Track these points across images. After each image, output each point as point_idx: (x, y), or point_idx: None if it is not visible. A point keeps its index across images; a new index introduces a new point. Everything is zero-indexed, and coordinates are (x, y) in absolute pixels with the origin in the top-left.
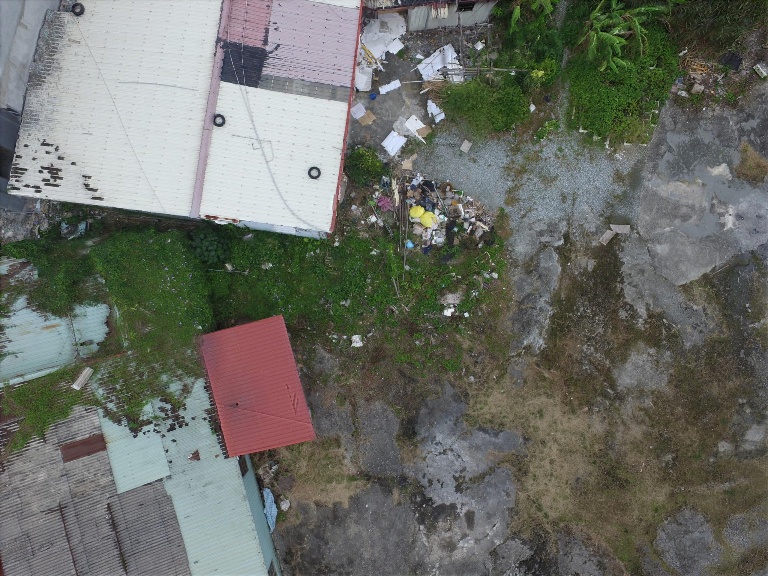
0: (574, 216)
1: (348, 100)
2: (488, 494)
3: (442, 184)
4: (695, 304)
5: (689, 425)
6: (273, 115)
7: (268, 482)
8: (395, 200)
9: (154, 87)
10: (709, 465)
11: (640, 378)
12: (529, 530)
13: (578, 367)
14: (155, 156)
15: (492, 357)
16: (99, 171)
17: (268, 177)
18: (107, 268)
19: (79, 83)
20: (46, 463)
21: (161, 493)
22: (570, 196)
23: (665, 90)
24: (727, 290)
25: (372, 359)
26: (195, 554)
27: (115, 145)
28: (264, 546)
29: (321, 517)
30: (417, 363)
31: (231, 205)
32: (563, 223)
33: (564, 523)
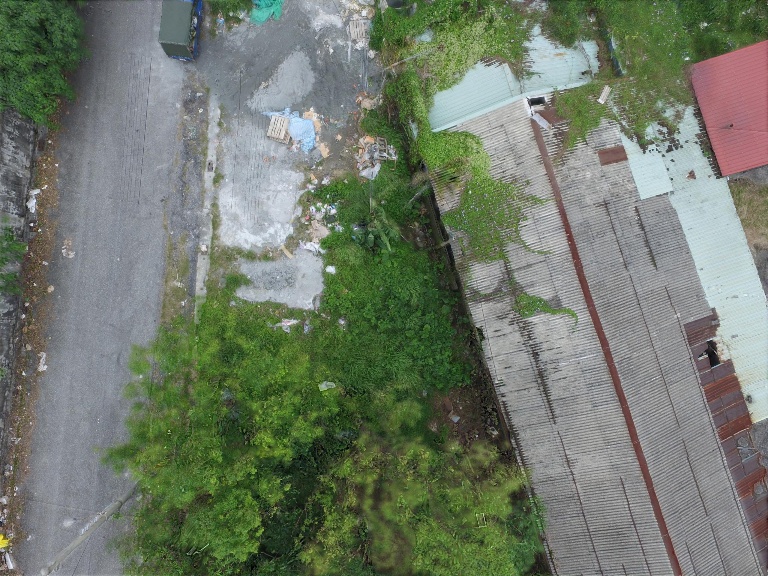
0: None
1: None
2: None
3: None
4: None
5: None
6: None
7: None
8: None
9: None
10: None
11: None
12: None
13: None
14: None
15: None
16: None
17: None
18: None
19: None
20: (590, 163)
21: (668, 205)
22: None
23: None
24: None
25: None
26: (700, 262)
27: None
28: None
29: (761, 259)
30: None
31: None
32: None
33: None
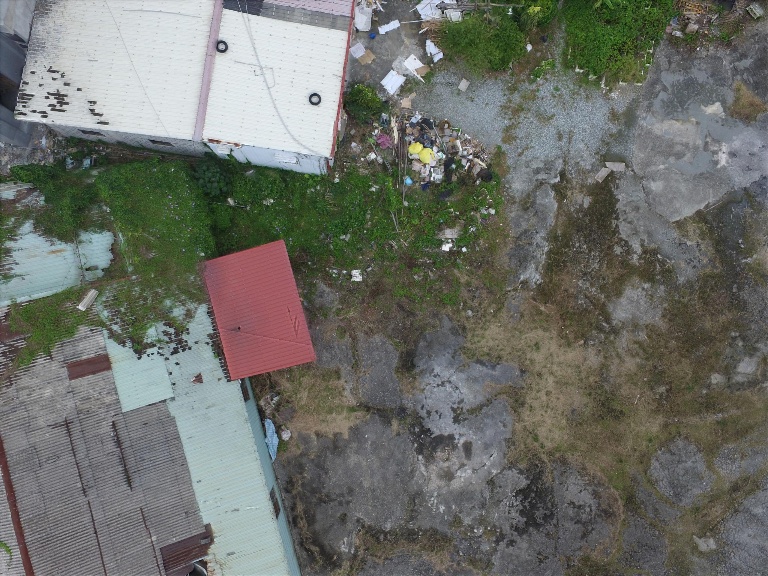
0: (570, 154)
1: (348, 29)
2: (485, 425)
3: (440, 122)
4: (689, 240)
5: (683, 358)
6: (275, 43)
7: (269, 413)
8: (394, 138)
9: (158, 14)
10: (702, 397)
11: (635, 312)
12: (525, 460)
13: (574, 301)
14: (159, 81)
15: (489, 291)
16: (104, 96)
17: (270, 103)
18: (112, 195)
19: (84, 11)
20: (53, 379)
21: (165, 414)
22: (566, 134)
23: (660, 30)
24: (720, 226)
25: (371, 293)
26: (198, 473)
27: (120, 71)
28: (265, 471)
29: (321, 447)
30: (416, 297)
31: (233, 129)
32: (559, 161)
33: (560, 453)
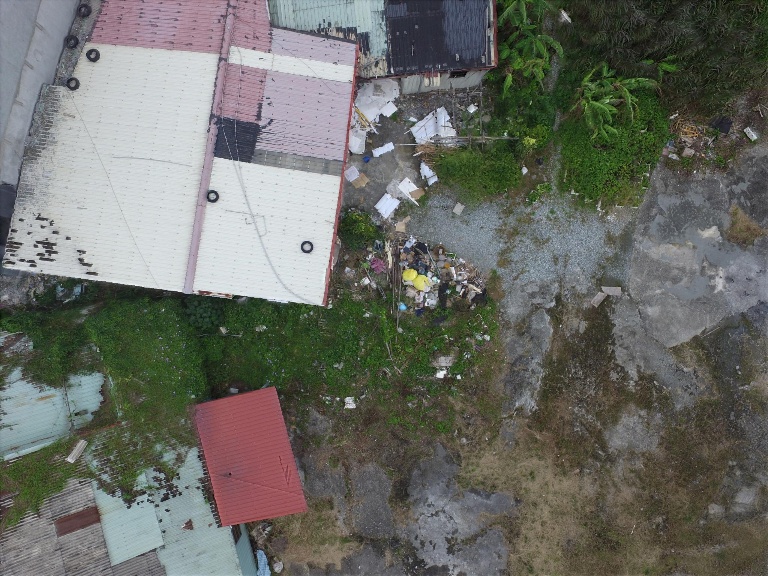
0: (566, 278)
1: (341, 174)
2: (480, 556)
3: (435, 247)
4: (686, 366)
5: (679, 487)
6: (266, 190)
7: (261, 544)
8: (388, 262)
9: (148, 162)
10: (699, 527)
11: (631, 440)
12: None
13: (569, 429)
14: (149, 231)
15: (484, 419)
16: (93, 246)
17: (261, 252)
18: (101, 339)
19: (74, 158)
20: (40, 538)
21: (154, 563)
22: (562, 258)
23: (656, 153)
24: (717, 352)
25: (365, 421)
26: None
27: (109, 220)
28: None
29: None
30: (410, 425)
31: (224, 280)
32: (555, 285)
33: None
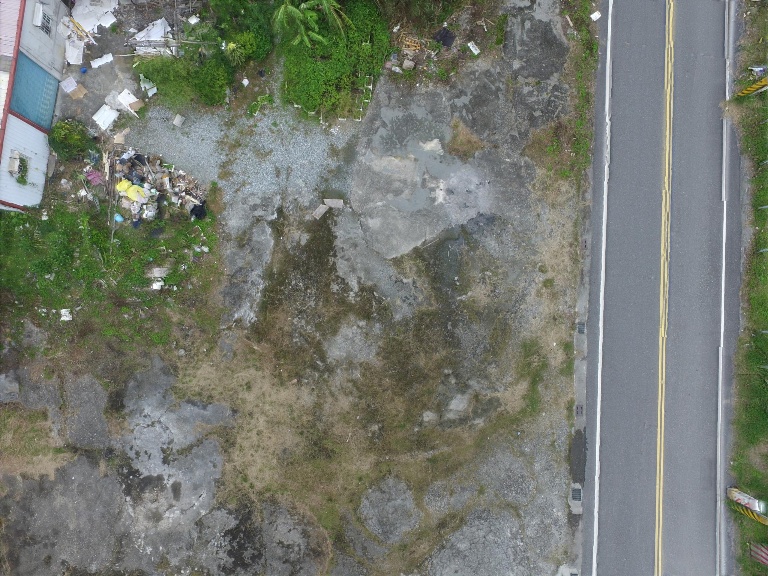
0: (288, 190)
1: (9, 70)
2: (195, 465)
3: (153, 158)
4: (405, 277)
5: (395, 396)
6: None
7: None
8: (106, 174)
9: None
10: (414, 434)
11: (349, 350)
12: (235, 500)
13: (288, 340)
14: None
15: (203, 330)
16: None
17: None
18: None
19: None
20: None
21: None
22: (284, 171)
23: (377, 66)
24: (437, 263)
25: (81, 333)
26: None
27: None
28: None
29: (27, 490)
30: (126, 336)
31: None
32: (277, 197)
33: (270, 492)
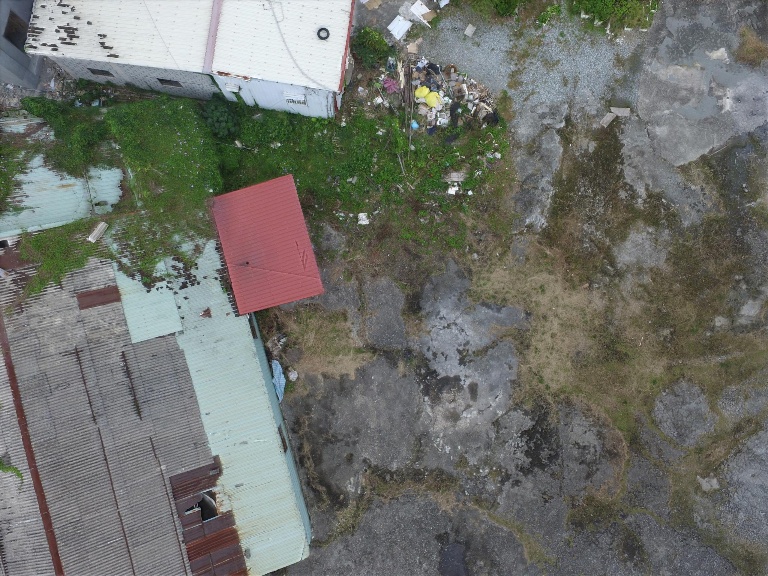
0: (575, 99)
1: None
2: (491, 366)
3: (447, 66)
4: (693, 184)
5: (687, 301)
6: None
7: (276, 354)
8: (401, 82)
9: None
10: (706, 339)
11: (639, 255)
12: (531, 401)
13: (579, 245)
14: (169, 15)
15: (495, 235)
16: (114, 30)
17: (278, 37)
18: (121, 130)
19: None
20: (63, 308)
21: (174, 346)
22: (571, 80)
23: None
24: (724, 171)
25: (378, 236)
26: (207, 406)
27: (130, 5)
28: (273, 407)
29: (328, 388)
30: (422, 240)
31: (242, 62)
32: (565, 106)
33: (565, 394)
